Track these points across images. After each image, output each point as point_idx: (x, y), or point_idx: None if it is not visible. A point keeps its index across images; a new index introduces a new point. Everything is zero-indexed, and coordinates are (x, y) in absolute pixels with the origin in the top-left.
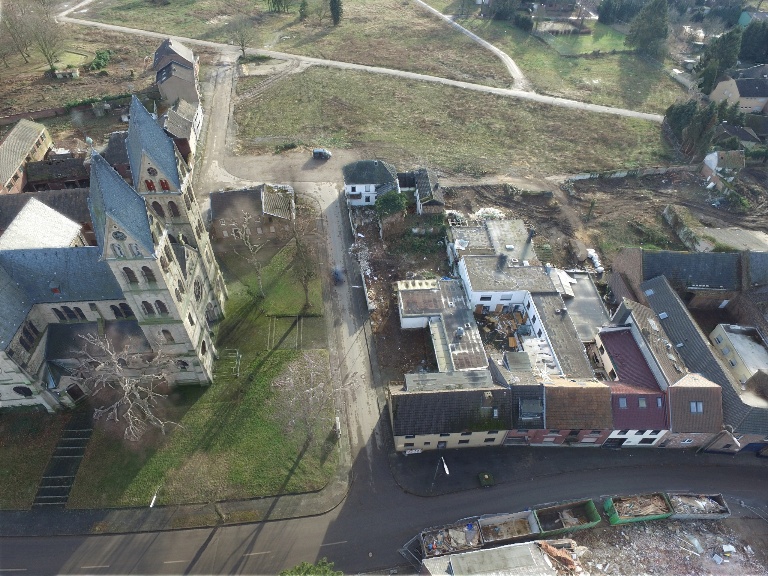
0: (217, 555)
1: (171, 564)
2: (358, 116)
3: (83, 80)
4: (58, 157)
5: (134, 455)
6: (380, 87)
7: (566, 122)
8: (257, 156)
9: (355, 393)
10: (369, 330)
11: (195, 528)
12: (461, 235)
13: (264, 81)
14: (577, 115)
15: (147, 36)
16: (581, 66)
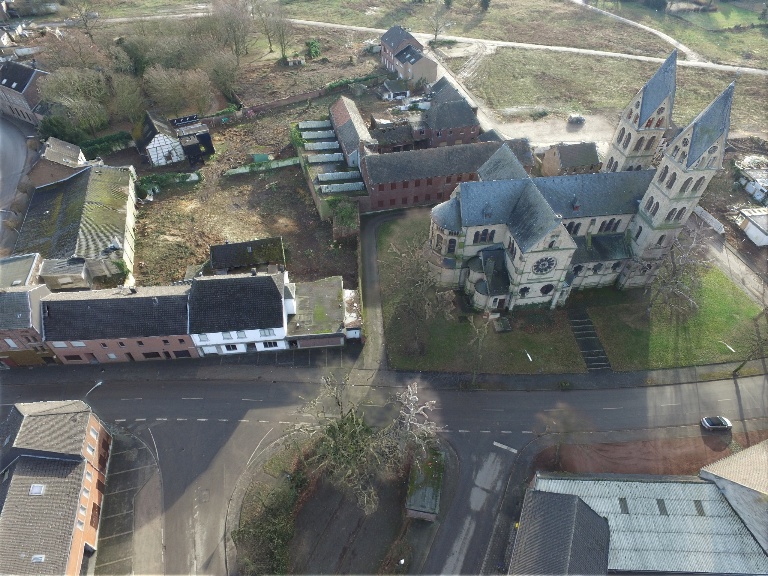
0: (752, 395)
1: (724, 401)
2: (576, 88)
3: (312, 66)
4: (383, 126)
5: (636, 335)
6: (574, 63)
7: (760, 86)
8: (521, 123)
9: (760, 291)
10: (732, 248)
11: (719, 380)
12: (756, 175)
13: (468, 62)
14: (765, 80)
15: (329, 27)
16: (733, 39)
